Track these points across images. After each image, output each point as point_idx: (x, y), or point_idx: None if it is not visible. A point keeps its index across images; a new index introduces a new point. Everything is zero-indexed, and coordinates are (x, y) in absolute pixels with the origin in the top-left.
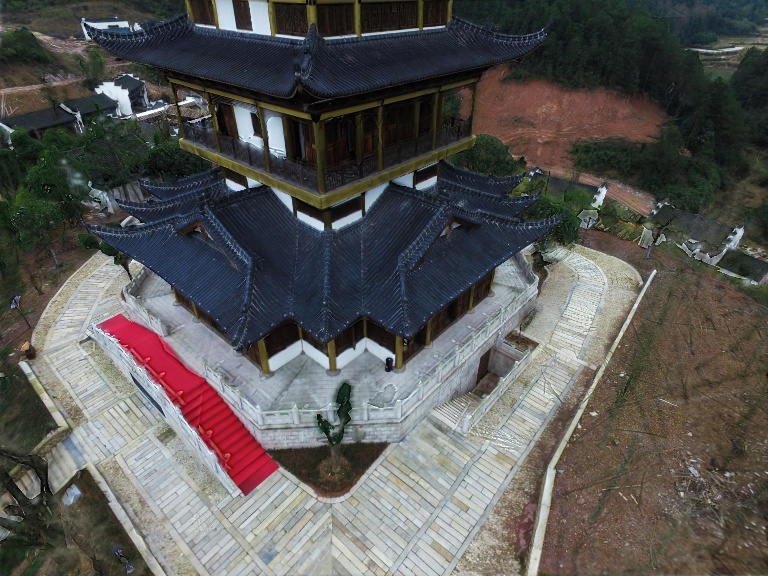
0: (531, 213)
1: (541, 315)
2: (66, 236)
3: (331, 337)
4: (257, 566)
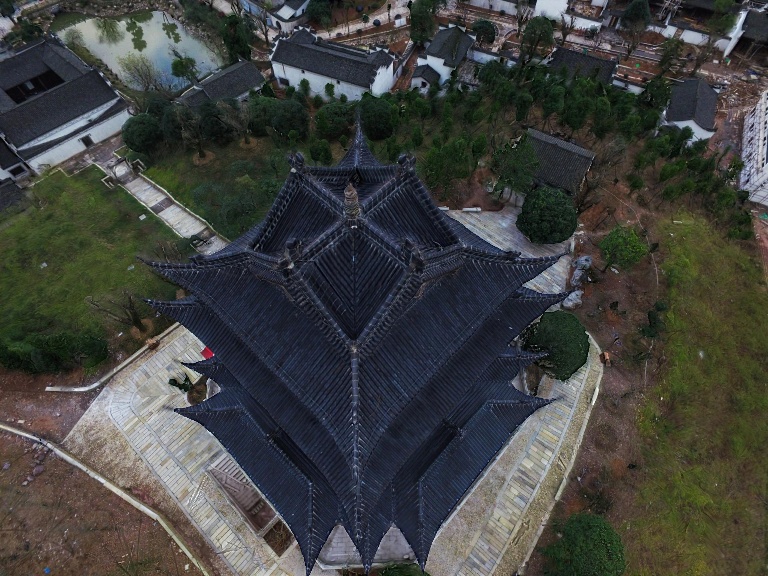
0: (388, 575)
1: (317, 574)
2: (449, 182)
3: (193, 369)
4: (166, 364)
